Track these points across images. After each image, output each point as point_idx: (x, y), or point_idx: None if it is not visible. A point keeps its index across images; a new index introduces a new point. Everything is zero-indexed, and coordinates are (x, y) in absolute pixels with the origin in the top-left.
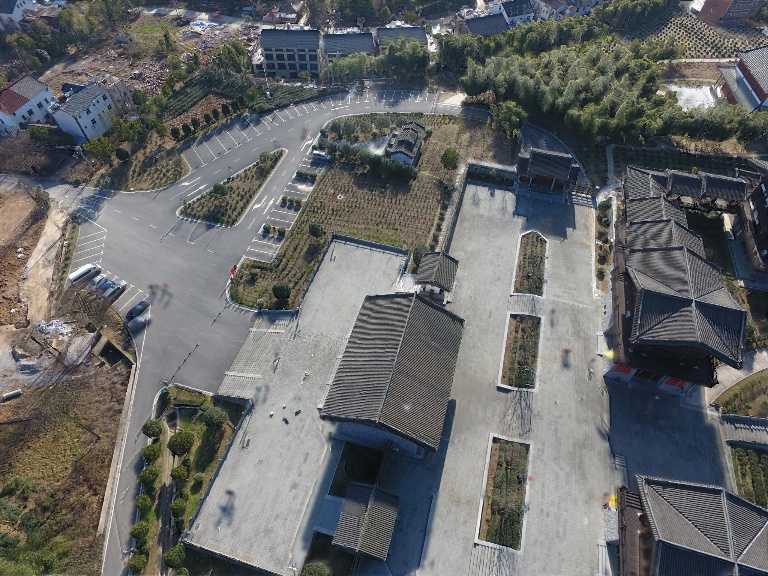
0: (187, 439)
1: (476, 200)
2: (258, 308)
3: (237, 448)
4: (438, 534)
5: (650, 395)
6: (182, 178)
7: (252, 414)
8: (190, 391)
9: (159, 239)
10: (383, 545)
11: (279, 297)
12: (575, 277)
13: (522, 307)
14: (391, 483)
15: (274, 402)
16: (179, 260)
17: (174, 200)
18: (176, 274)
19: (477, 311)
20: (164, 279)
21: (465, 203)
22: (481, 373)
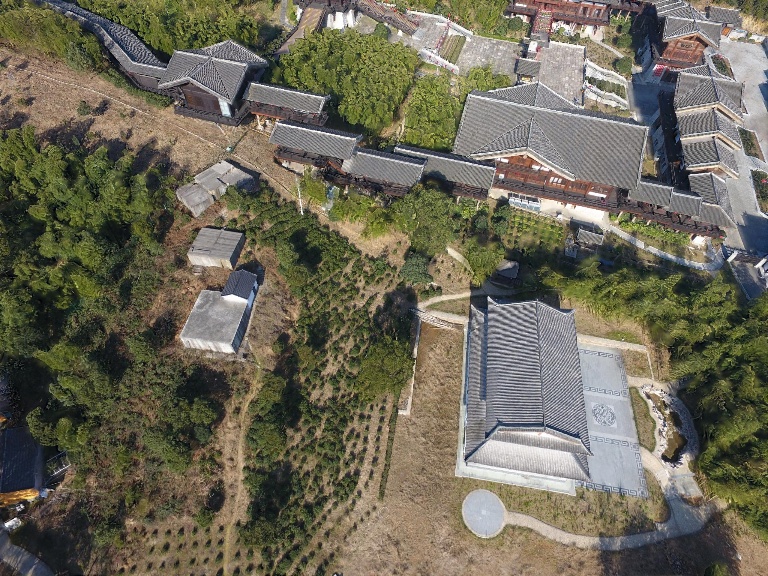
0: None
1: None
2: None
3: None
4: None
5: None
6: None
7: None
8: None
9: None
10: None
11: None
12: (728, 181)
13: (761, 163)
14: None
15: None
16: None
17: None
18: None
19: None
20: None
21: None
22: (767, 137)
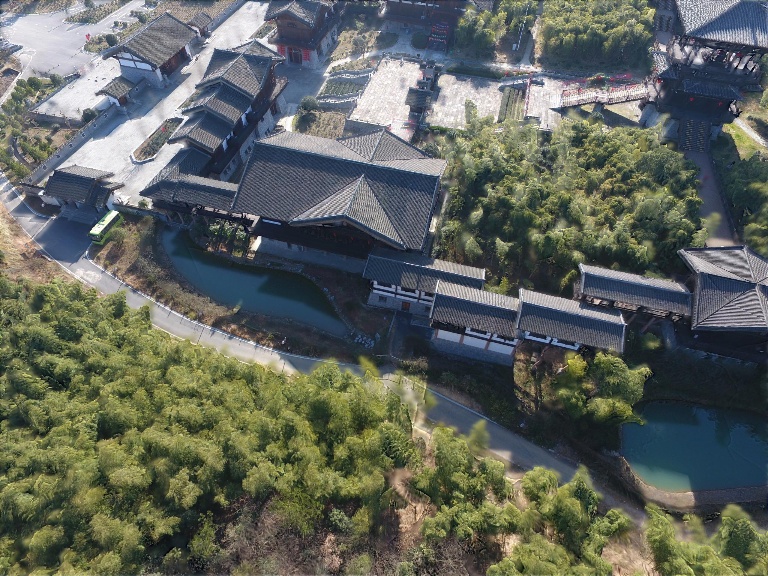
0: (38, 80)
1: (249, 7)
2: (99, 52)
3: (66, 89)
4: (158, 108)
5: (297, 69)
6: (71, 7)
7: (78, 79)
8: (49, 79)
9: (48, 31)
10: (119, 94)
11: (110, 43)
12: None
13: None
14: (142, 96)
15: (92, 76)
16: (58, 37)
17: (63, 16)
18: (54, 42)
19: (223, 46)
20: (46, 44)
21: (242, 8)
22: None
